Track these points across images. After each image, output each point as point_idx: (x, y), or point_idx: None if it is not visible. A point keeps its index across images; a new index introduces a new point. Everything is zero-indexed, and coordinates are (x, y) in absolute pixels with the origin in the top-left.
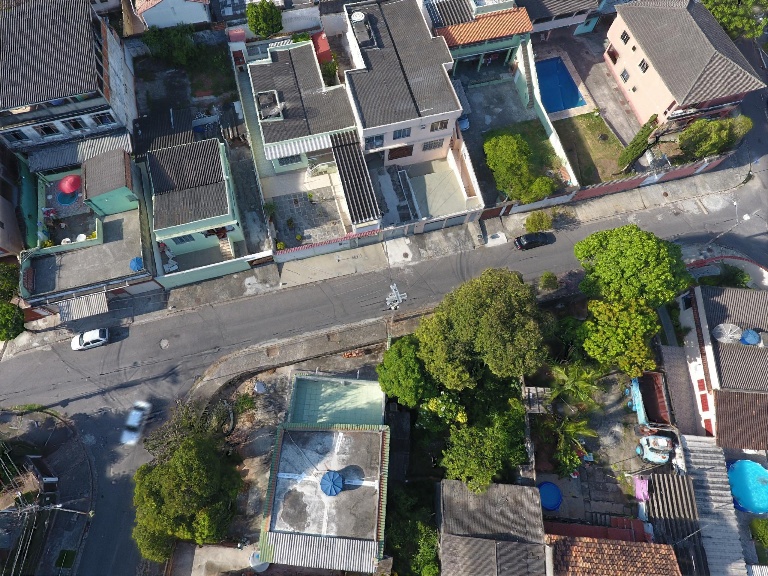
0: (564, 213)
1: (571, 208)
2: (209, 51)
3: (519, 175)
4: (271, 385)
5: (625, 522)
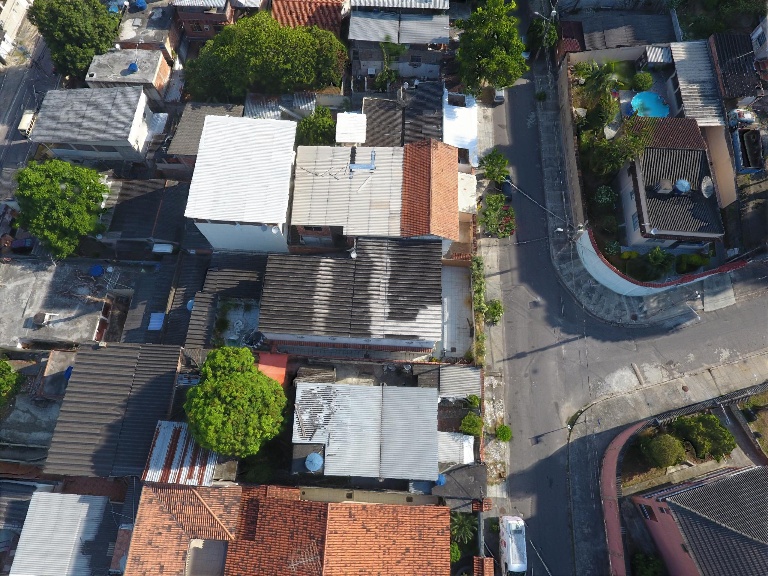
0: None
1: None
2: None
3: None
4: None
5: (763, 76)
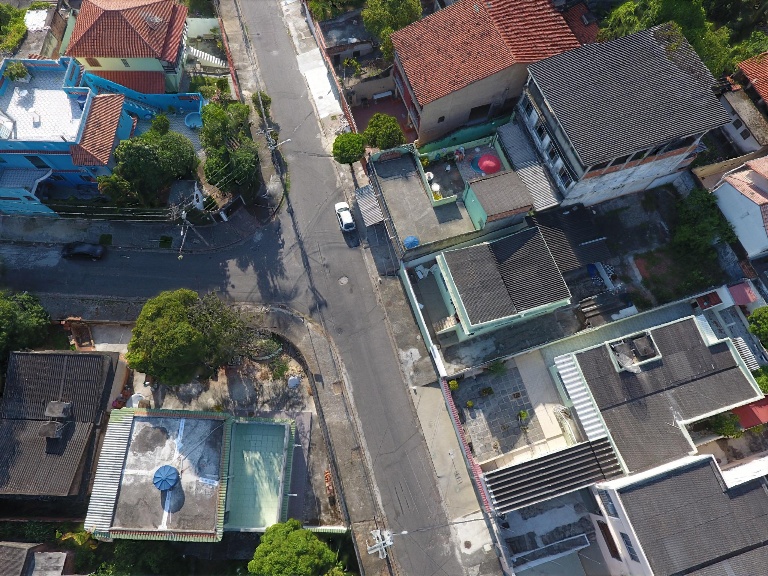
0: None
1: None
2: (709, 263)
3: None
4: (296, 393)
5: None
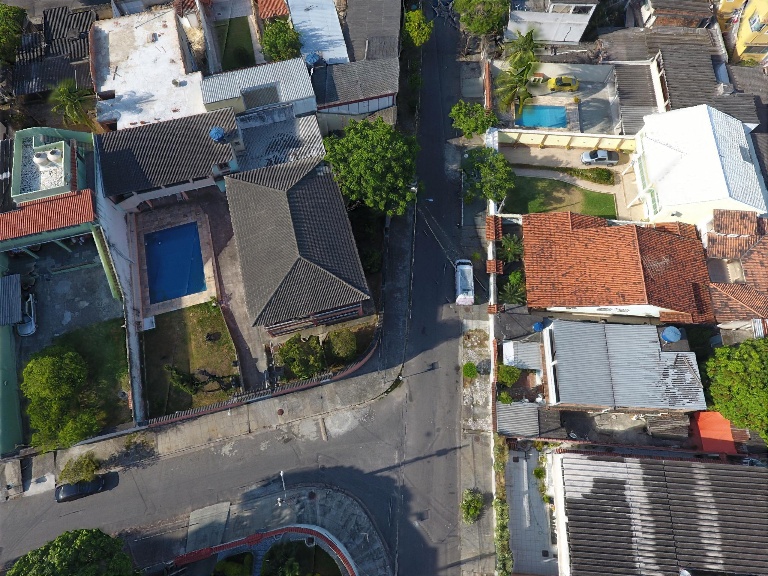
0: (142, 443)
1: (153, 435)
2: None
3: (46, 416)
4: None
5: None
